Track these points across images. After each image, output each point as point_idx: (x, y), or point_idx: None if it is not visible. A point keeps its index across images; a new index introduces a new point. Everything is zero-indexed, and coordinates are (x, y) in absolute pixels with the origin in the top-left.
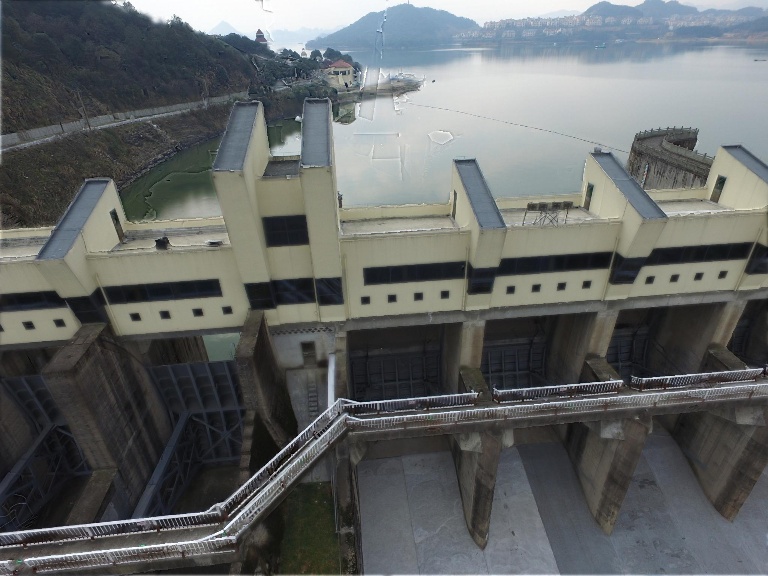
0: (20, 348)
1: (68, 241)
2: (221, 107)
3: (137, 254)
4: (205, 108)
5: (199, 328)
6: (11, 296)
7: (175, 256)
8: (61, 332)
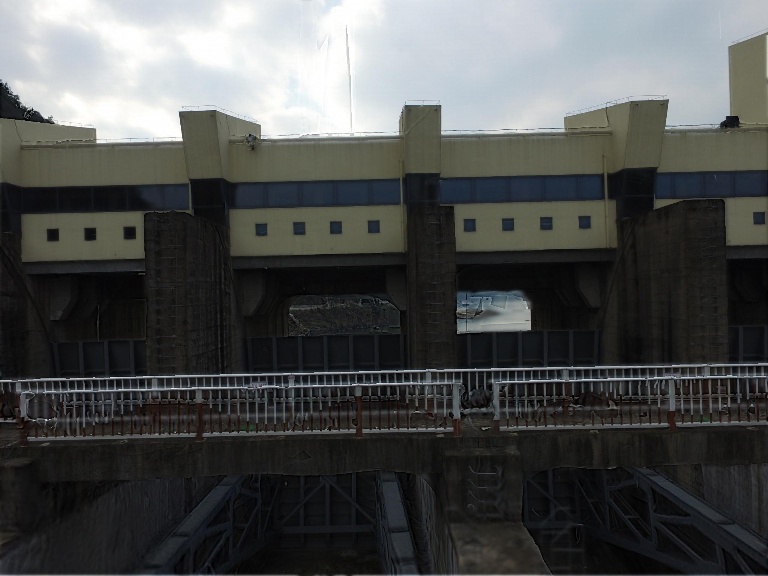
0: (517, 261)
1: None
2: (341, 309)
3: (704, 130)
4: (328, 309)
5: (756, 243)
6: (540, 180)
7: (748, 135)
8: (581, 236)
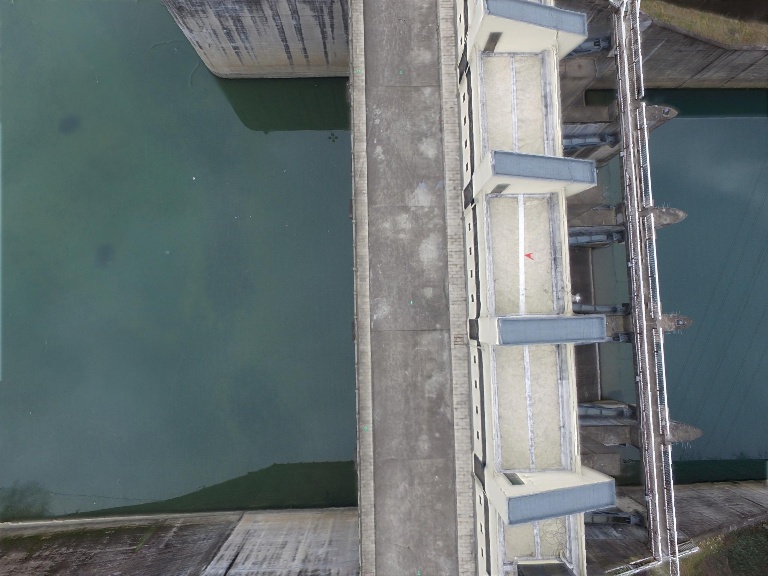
0: None
1: (564, 18)
2: None
3: None
4: None
5: None
6: None
7: None
8: None
